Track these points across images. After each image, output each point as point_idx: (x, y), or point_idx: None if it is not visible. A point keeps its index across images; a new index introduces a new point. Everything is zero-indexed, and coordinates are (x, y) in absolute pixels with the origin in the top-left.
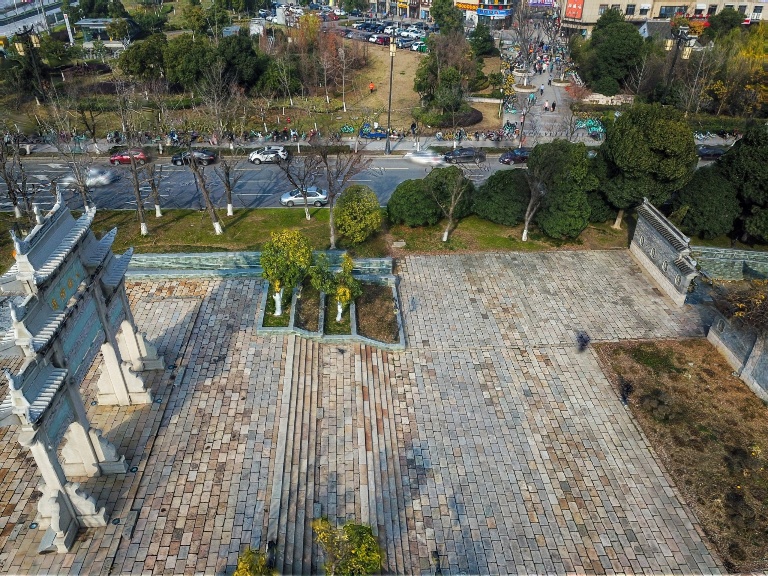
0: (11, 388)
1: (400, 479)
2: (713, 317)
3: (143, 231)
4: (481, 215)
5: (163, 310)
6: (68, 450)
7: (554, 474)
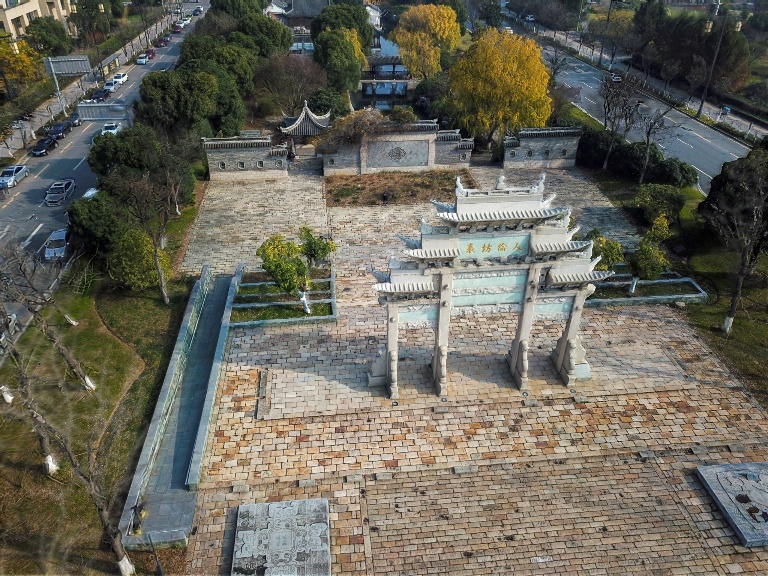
0: None
1: None
2: (303, 171)
3: (52, 467)
4: None
5: (290, 391)
6: None
7: None
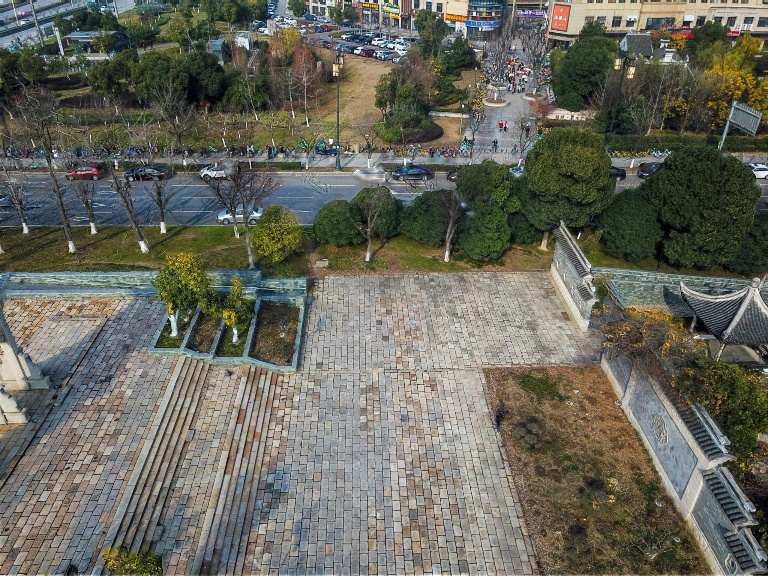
0: None
1: (253, 503)
2: None
3: (71, 249)
4: (407, 235)
5: (66, 329)
6: None
7: (406, 501)
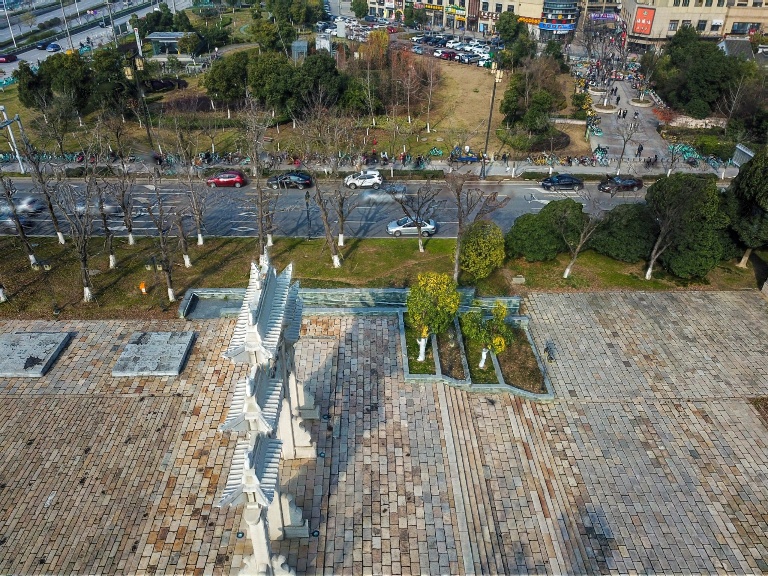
0: (247, 467)
1: (584, 550)
2: None
3: (261, 263)
4: (600, 251)
5: (302, 351)
6: None
7: (747, 550)
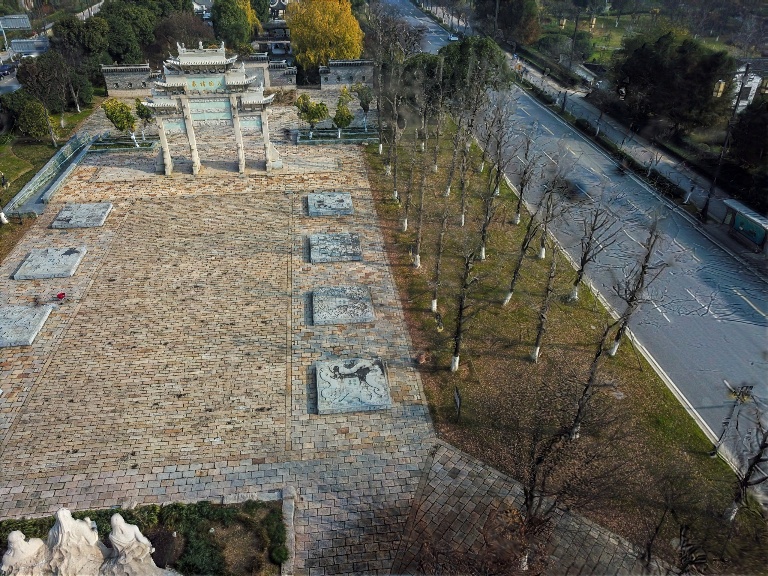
0: None
1: None
2: None
3: None
4: (48, 112)
5: (111, 173)
6: (241, 155)
7: None
